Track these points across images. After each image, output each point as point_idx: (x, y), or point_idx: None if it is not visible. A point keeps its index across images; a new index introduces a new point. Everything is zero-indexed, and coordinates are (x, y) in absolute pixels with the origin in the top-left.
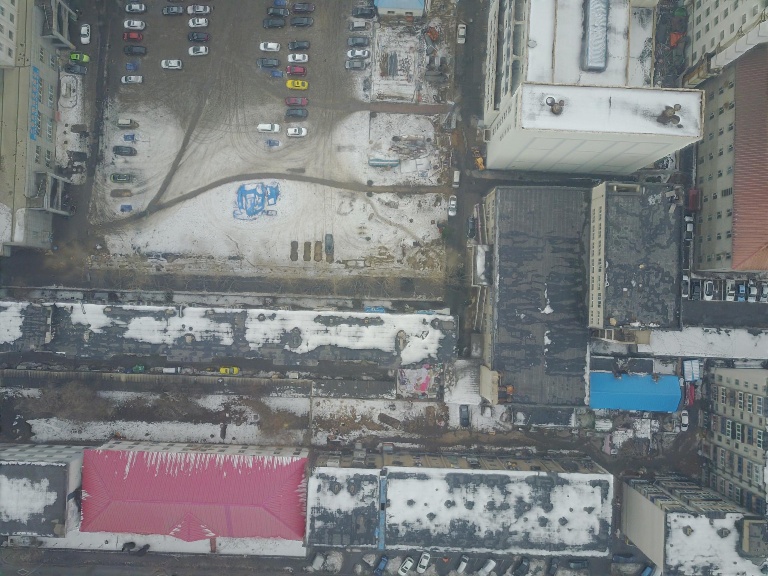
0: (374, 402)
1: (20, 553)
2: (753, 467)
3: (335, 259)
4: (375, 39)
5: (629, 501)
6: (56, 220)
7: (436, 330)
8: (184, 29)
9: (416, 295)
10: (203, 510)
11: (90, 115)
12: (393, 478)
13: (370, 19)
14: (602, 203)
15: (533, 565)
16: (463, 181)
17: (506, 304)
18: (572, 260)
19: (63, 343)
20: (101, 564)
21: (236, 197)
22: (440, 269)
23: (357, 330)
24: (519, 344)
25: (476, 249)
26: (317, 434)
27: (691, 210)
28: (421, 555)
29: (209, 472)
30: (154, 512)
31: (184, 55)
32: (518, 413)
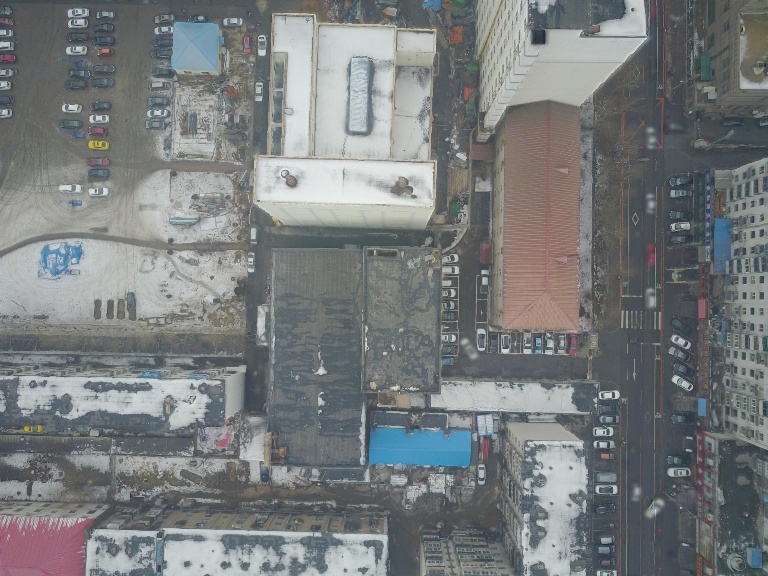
0: None
1: None
2: (517, 529)
3: (137, 317)
4: (175, 98)
5: (421, 557)
6: None
7: (203, 395)
8: None
9: (217, 351)
10: None
11: None
12: (170, 540)
13: (170, 79)
14: None
15: None
16: (263, 237)
17: (282, 366)
18: (346, 321)
19: None
20: None
21: (40, 257)
22: None
23: (126, 396)
24: (294, 405)
25: (257, 310)
26: (121, 490)
27: (485, 264)
28: None
29: None
30: None
31: None
32: (313, 469)
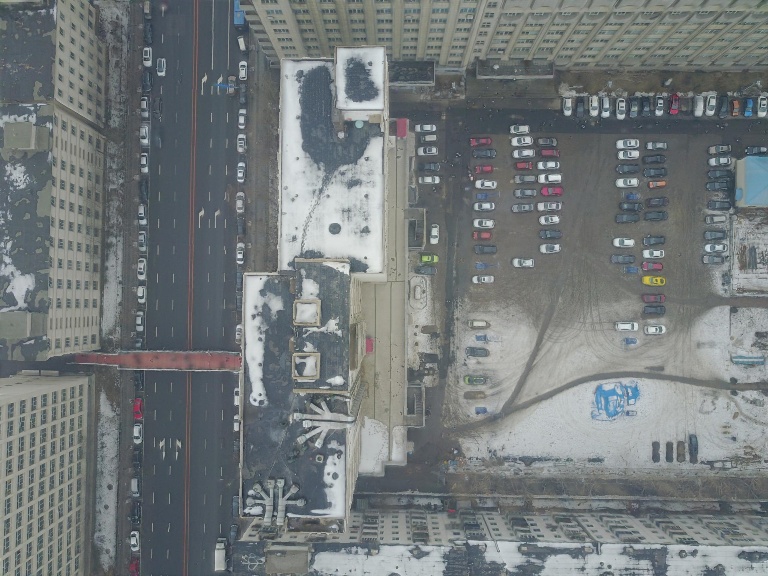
0: None
1: None
2: None
3: (699, 460)
4: (732, 232)
5: None
6: None
7: None
8: (533, 226)
9: None
10: None
11: (440, 316)
12: None
13: (726, 211)
14: None
15: None
16: None
17: None
18: None
19: None
20: None
21: (594, 397)
22: None
23: None
24: None
25: None
26: None
27: None
28: None
29: None
30: None
31: (534, 252)
32: None
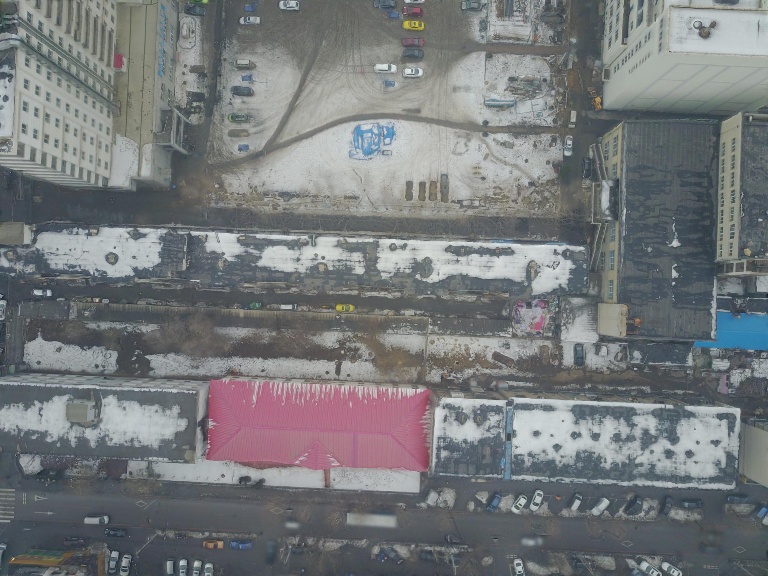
0: (488, 341)
1: (138, 485)
2: None
3: (450, 199)
4: None
5: (748, 440)
6: (175, 159)
7: (567, 260)
8: None
9: (531, 235)
10: (331, 438)
11: (208, 56)
12: (519, 409)
13: None
14: (736, 134)
15: (646, 504)
16: (578, 122)
17: (633, 238)
18: (700, 194)
19: (198, 271)
20: (217, 497)
21: (352, 137)
22: (555, 209)
23: (488, 260)
24: (646, 277)
25: (600, 184)
26: (431, 372)
27: None
28: (534, 493)
29: (335, 402)
30: (282, 440)
31: None
32: (635, 352)
